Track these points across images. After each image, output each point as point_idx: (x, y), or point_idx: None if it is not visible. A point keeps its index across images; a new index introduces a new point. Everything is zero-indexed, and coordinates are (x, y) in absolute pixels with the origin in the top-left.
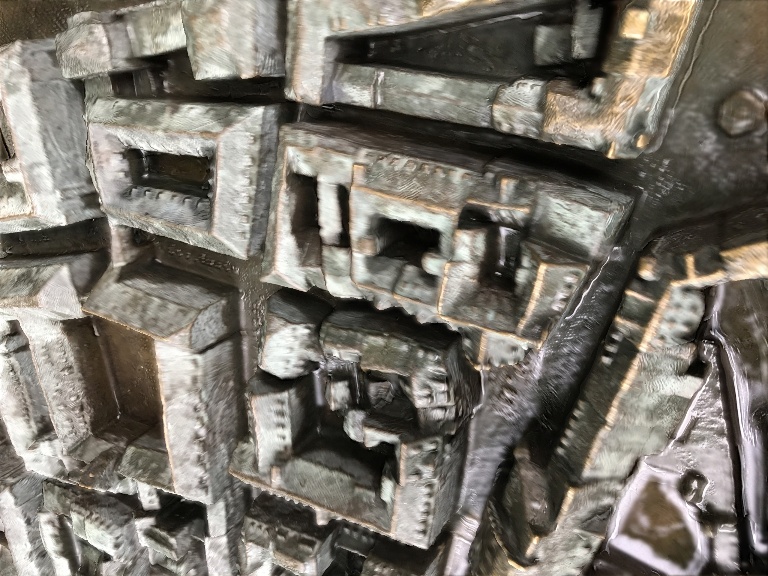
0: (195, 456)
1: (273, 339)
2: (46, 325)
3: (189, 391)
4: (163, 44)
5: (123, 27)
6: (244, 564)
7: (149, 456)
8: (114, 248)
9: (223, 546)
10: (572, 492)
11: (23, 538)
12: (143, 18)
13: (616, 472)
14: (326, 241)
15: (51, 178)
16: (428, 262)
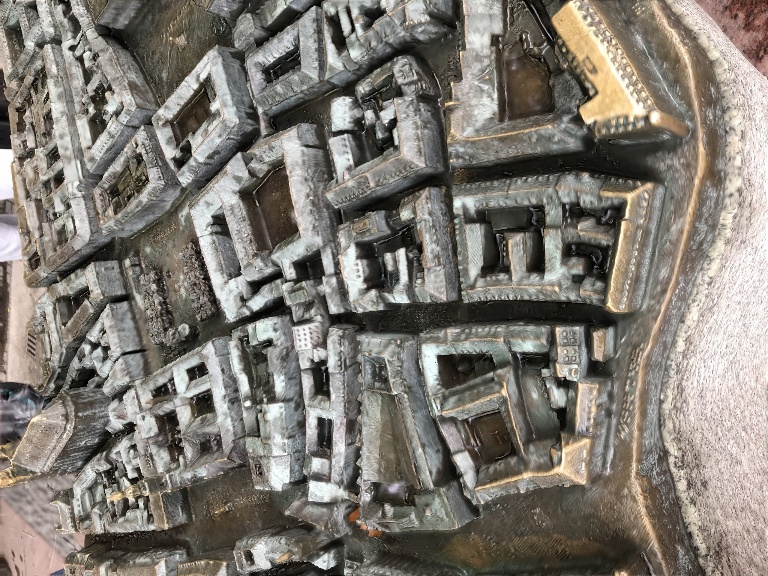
0: (309, 210)
1: (334, 105)
2: (231, 195)
3: (301, 169)
4: (275, 14)
5: (259, 17)
6: (340, 250)
7: (287, 239)
8: (262, 127)
9: (334, 284)
10: (460, 53)
11: (220, 383)
12: (267, 10)
13: (483, 44)
14: (346, 36)
15: (231, 100)
16: (381, 3)
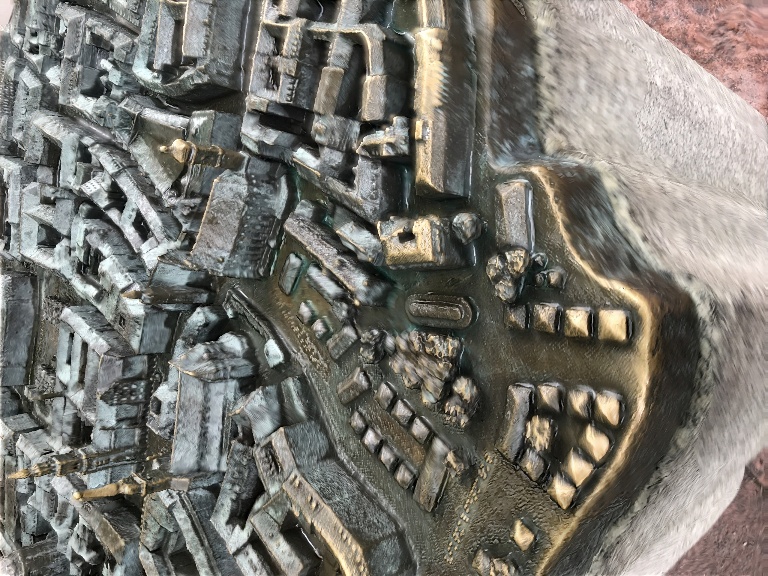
0: None
1: None
2: None
3: None
4: None
5: None
6: None
7: None
8: None
9: None
10: None
11: (84, 325)
12: None
13: None
14: None
15: None
16: None
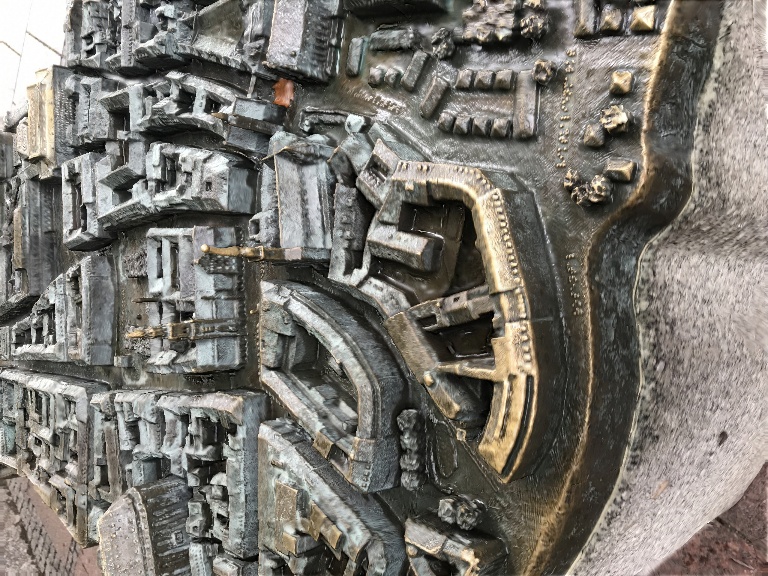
0: None
1: None
2: None
3: None
4: None
5: None
6: None
7: None
8: None
9: None
10: None
11: None
12: None
13: None
14: None
15: None
16: (88, 11)
